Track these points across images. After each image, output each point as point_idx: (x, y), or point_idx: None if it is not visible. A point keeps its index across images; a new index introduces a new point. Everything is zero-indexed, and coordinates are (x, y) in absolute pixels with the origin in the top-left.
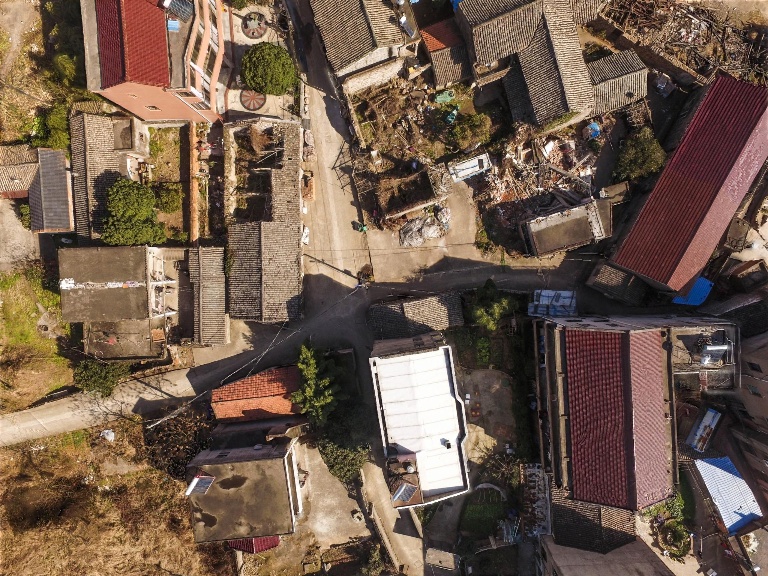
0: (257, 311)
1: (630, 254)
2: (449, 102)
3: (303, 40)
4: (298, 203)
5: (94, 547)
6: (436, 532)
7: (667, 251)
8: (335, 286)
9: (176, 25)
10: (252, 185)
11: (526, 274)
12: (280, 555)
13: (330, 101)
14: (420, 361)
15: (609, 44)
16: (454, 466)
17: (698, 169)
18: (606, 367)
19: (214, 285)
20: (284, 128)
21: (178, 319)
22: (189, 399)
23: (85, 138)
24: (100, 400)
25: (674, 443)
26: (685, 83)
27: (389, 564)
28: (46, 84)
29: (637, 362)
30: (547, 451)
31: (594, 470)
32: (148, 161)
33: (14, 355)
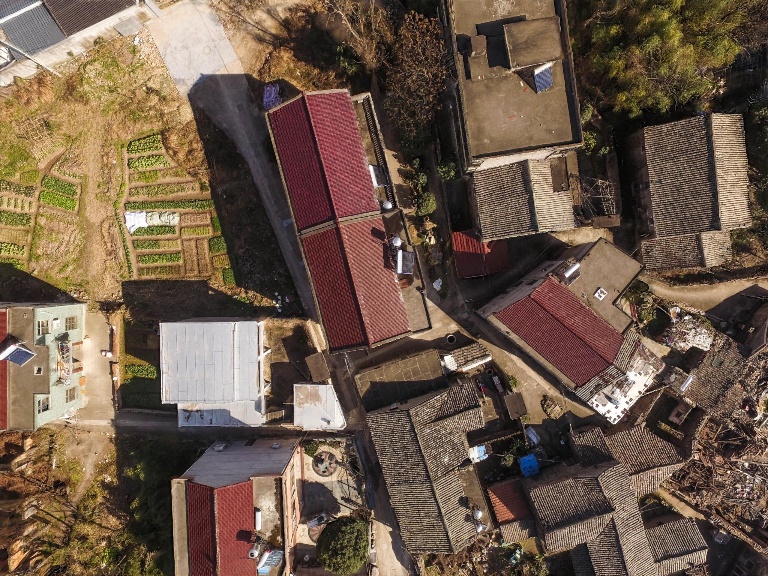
0: None
1: None
2: None
3: (371, 477)
4: None
5: None
6: None
7: None
8: None
9: (266, 570)
10: None
11: None
12: None
13: (396, 536)
14: None
15: (667, 491)
16: None
17: None
18: None
19: None
20: None
21: None
22: None
23: None
24: None
25: None
26: None
27: None
28: None
29: None
30: None
31: None
32: None
33: None
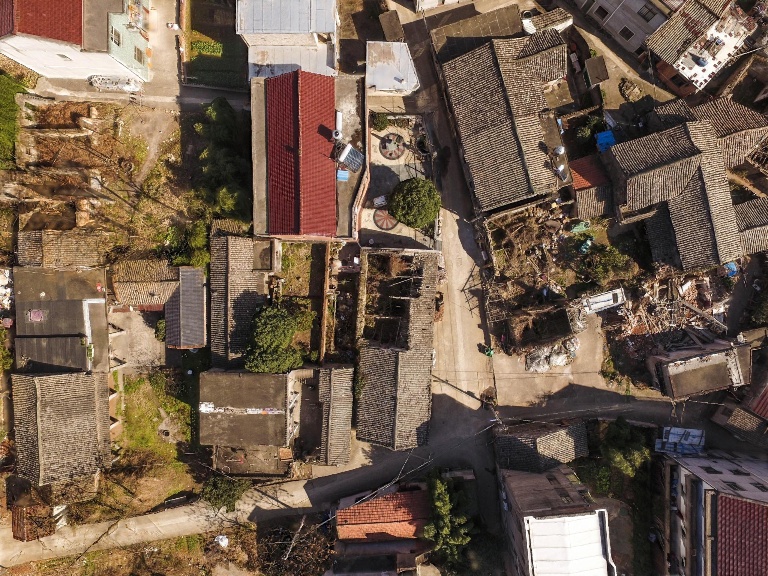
0: (388, 438)
1: None
2: (583, 231)
3: (440, 163)
4: (432, 330)
5: None
6: None
7: None
8: (457, 407)
9: (346, 175)
10: (381, 304)
11: (651, 405)
12: None
13: (463, 224)
14: (574, 522)
15: (748, 182)
16: None
17: None
18: (763, 540)
19: (342, 405)
20: (424, 257)
21: (299, 431)
22: (305, 510)
23: (228, 260)
24: None
25: None
26: None
27: None
28: (188, 200)
29: None
30: None
31: None
32: (278, 274)
33: (135, 460)
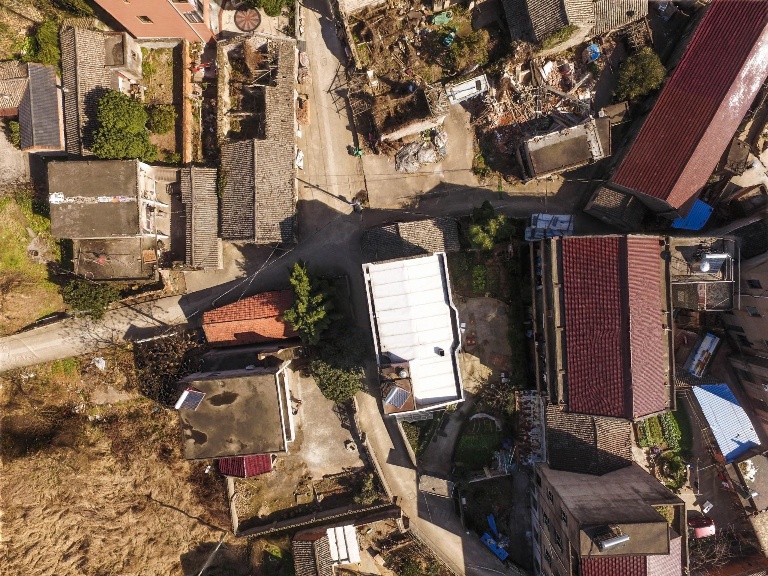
0: (250, 231)
1: (629, 172)
2: (447, 24)
3: None
4: (292, 123)
5: (84, 477)
6: (430, 463)
7: (666, 167)
8: (330, 212)
9: None
10: (246, 108)
11: (523, 201)
12: (272, 485)
13: (326, 23)
14: (414, 267)
15: None
16: (448, 375)
17: (699, 84)
18: (603, 274)
19: (207, 207)
20: (278, 45)
21: (170, 245)
22: (181, 327)
23: (76, 52)
24: (91, 327)
25: (671, 366)
26: (687, 5)
27: (382, 493)
28: None
29: (635, 268)
30: (543, 373)
31: (589, 343)
32: (141, 83)
33: (4, 279)
